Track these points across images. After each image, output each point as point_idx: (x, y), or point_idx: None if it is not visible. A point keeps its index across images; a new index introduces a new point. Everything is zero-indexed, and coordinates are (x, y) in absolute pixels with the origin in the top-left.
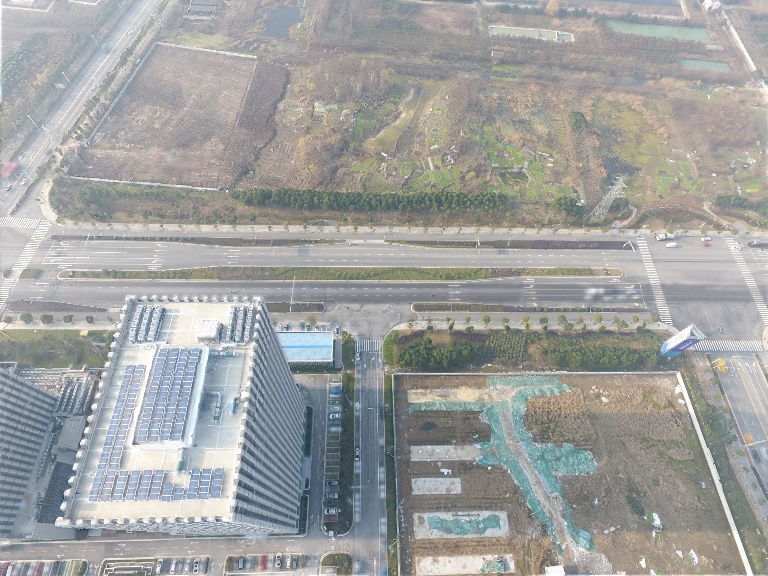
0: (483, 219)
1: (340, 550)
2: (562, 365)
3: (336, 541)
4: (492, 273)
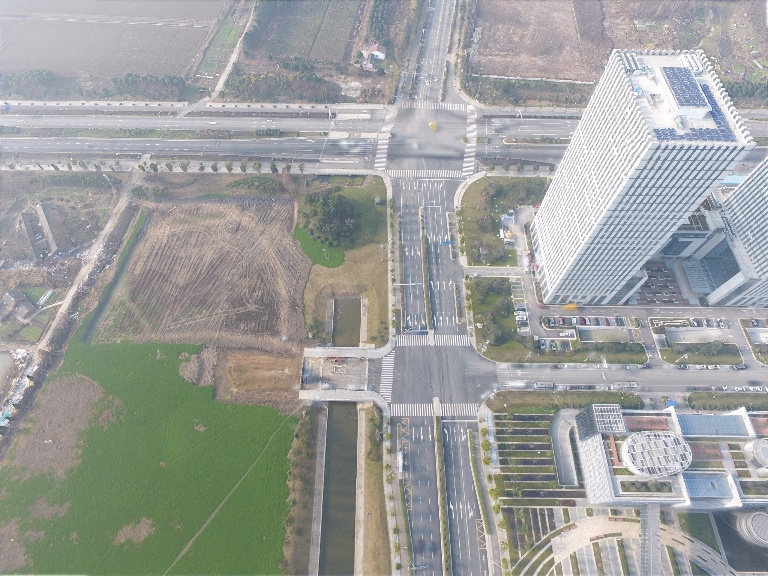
0: None
1: None
2: None
3: None
4: None
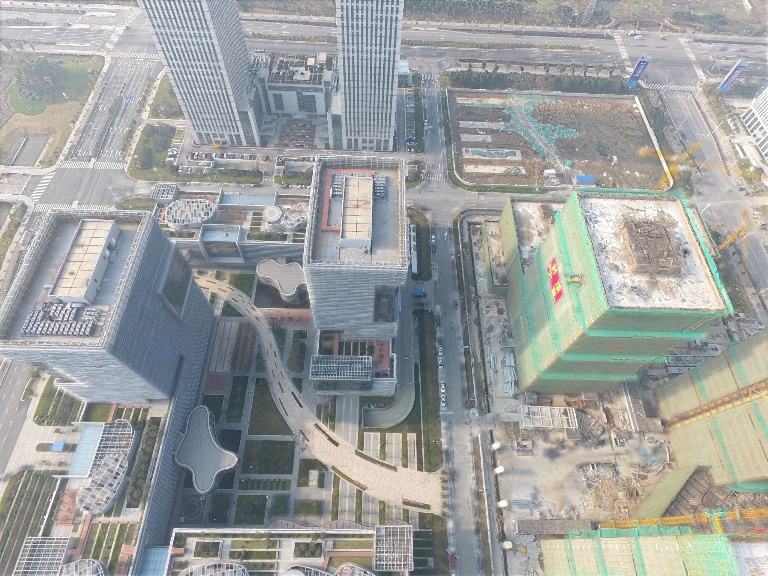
0: (506, 20)
1: None
2: (558, 90)
3: (415, 156)
4: (512, 46)
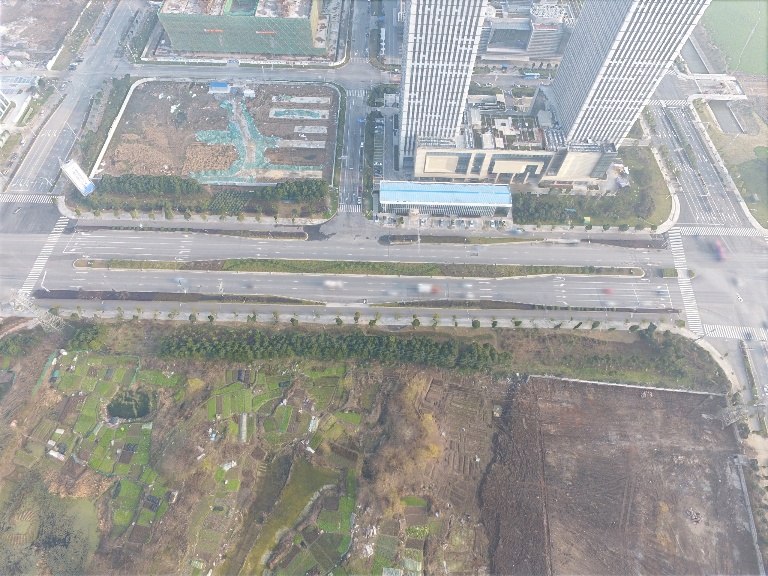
0: None
1: (374, 108)
2: None
3: None
4: None
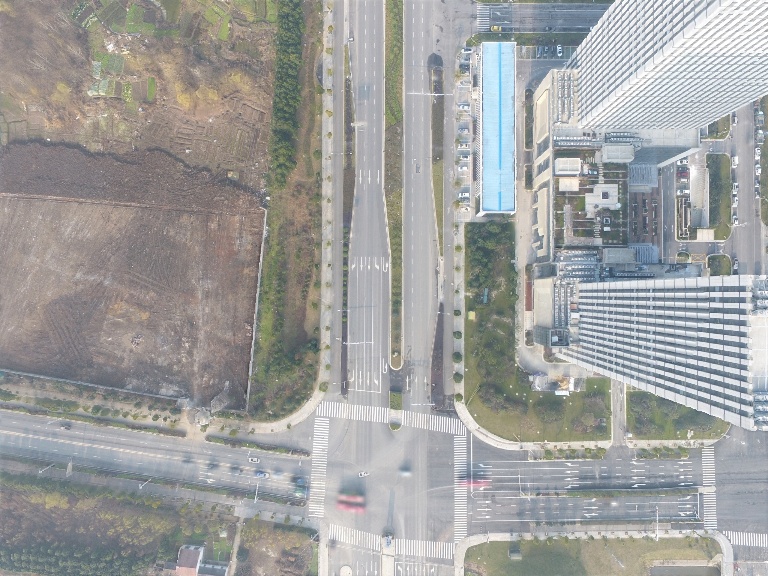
0: None
1: None
2: None
3: None
4: None
